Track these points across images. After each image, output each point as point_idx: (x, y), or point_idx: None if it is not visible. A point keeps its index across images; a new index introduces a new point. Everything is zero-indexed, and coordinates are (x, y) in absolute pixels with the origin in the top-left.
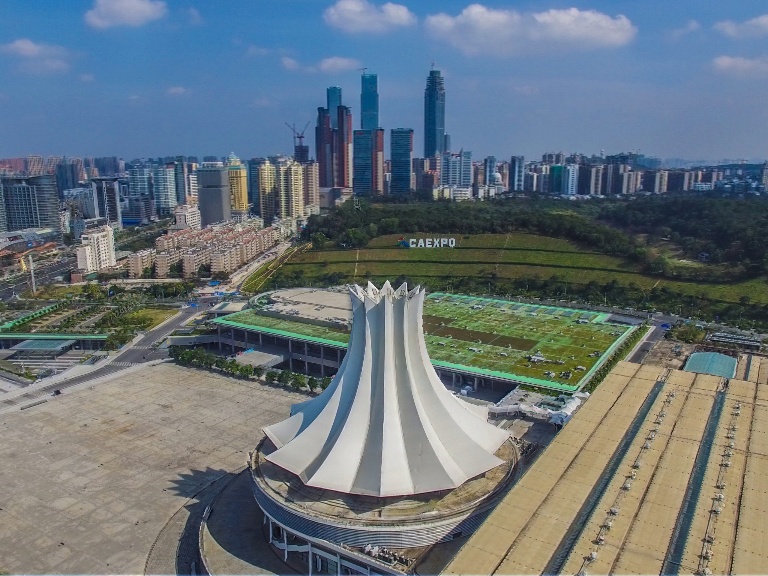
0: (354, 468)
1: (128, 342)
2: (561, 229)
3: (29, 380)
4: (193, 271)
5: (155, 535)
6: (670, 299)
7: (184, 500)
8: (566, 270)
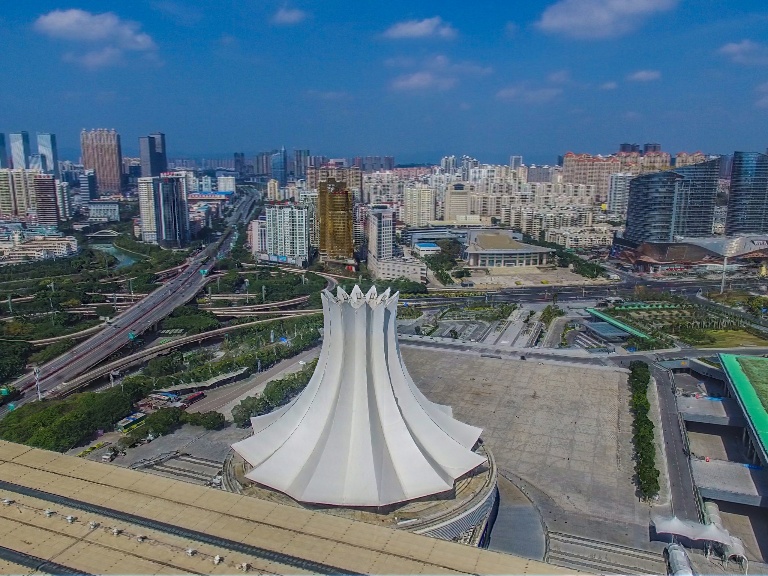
0: None
1: None
2: None
3: None
4: None
5: None
6: None
7: None
8: None
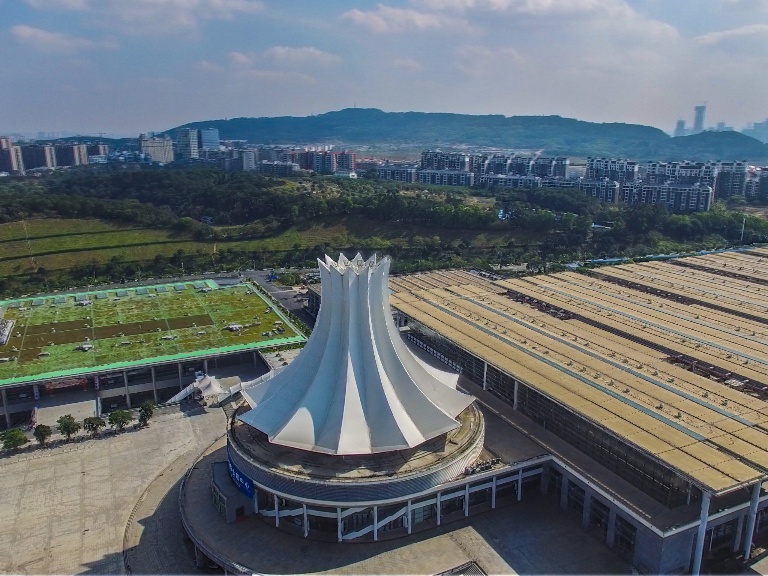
0: (410, 422)
1: None
2: (87, 209)
3: None
4: None
5: None
6: (237, 258)
7: None
8: (119, 250)
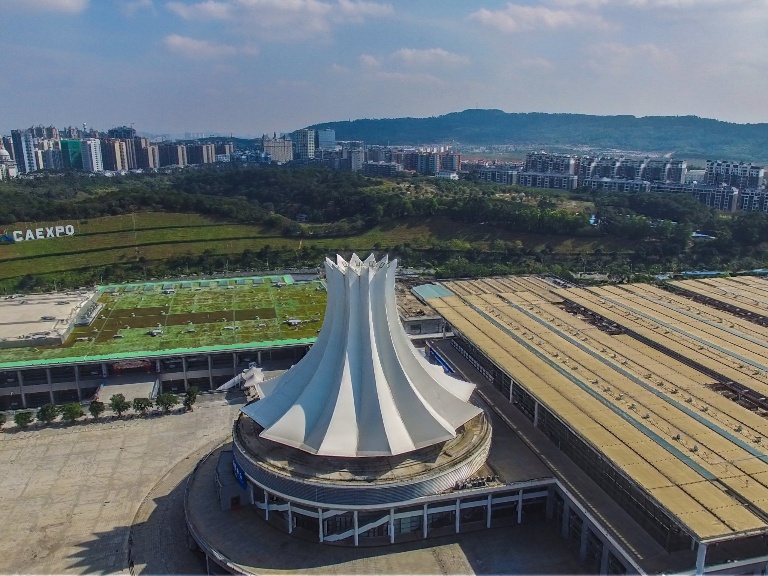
0: (403, 429)
1: None
2: (189, 204)
3: None
4: None
5: None
6: (319, 255)
7: (124, 573)
8: (213, 243)
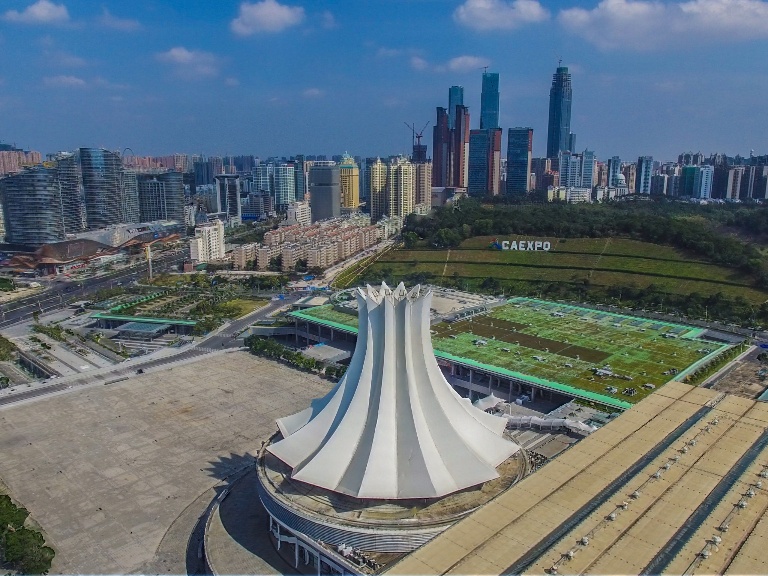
0: (344, 466)
1: (214, 329)
2: (667, 235)
3: (124, 358)
4: (291, 265)
5: (180, 511)
6: None
7: (215, 481)
8: (667, 280)
